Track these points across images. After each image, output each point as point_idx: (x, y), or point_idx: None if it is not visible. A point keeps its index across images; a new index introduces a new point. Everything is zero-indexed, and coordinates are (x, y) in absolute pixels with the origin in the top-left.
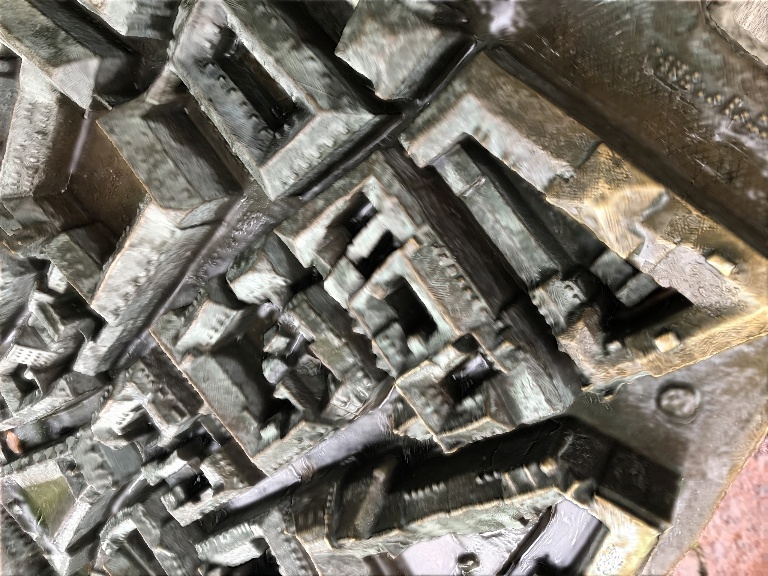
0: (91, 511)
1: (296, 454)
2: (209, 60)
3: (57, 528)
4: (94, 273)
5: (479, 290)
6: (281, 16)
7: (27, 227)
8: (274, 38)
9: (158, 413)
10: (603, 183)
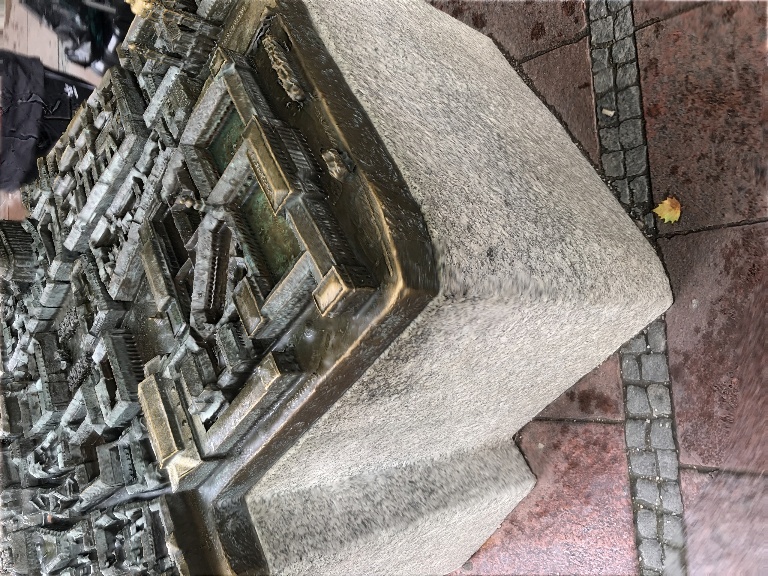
0: (61, 562)
1: (113, 575)
2: (127, 447)
3: (48, 563)
4: (86, 483)
5: (155, 551)
6: (142, 450)
7: (73, 459)
8: (137, 456)
9: (84, 541)
10: (169, 542)
